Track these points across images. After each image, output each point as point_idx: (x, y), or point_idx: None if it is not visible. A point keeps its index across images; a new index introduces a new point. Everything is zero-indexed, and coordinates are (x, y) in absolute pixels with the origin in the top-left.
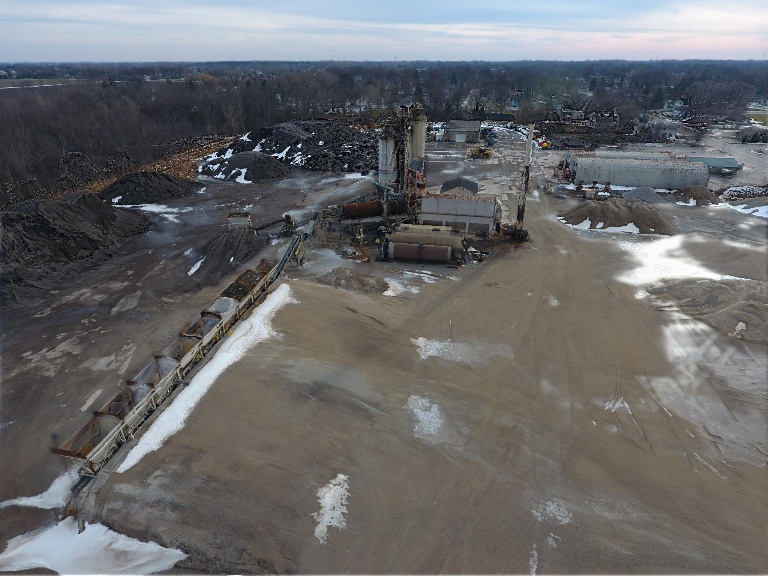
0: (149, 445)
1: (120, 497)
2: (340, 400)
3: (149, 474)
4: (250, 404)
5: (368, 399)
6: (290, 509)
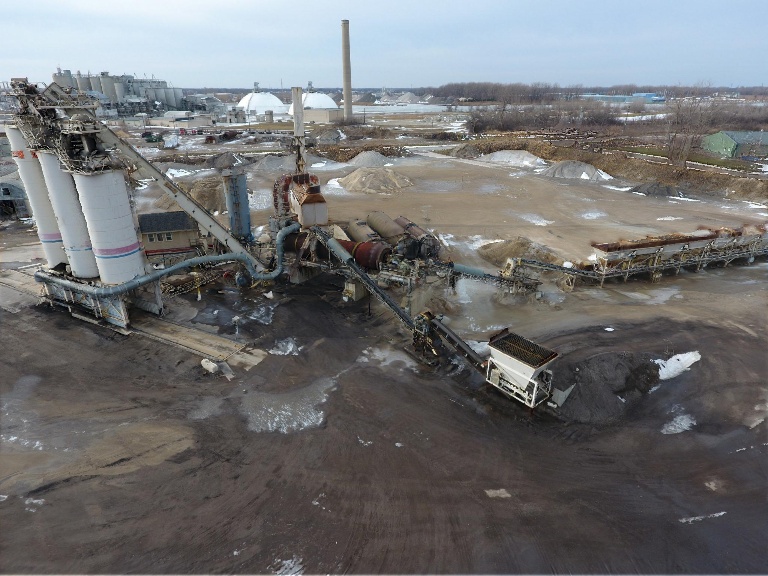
0: None
1: None
2: None
3: None
4: None
5: None
6: None
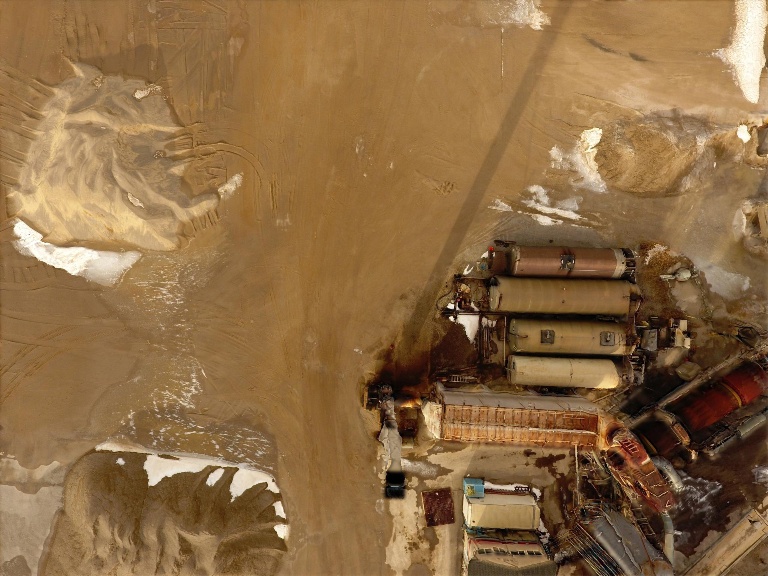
0: None
1: None
2: None
3: None
4: None
5: None
6: None
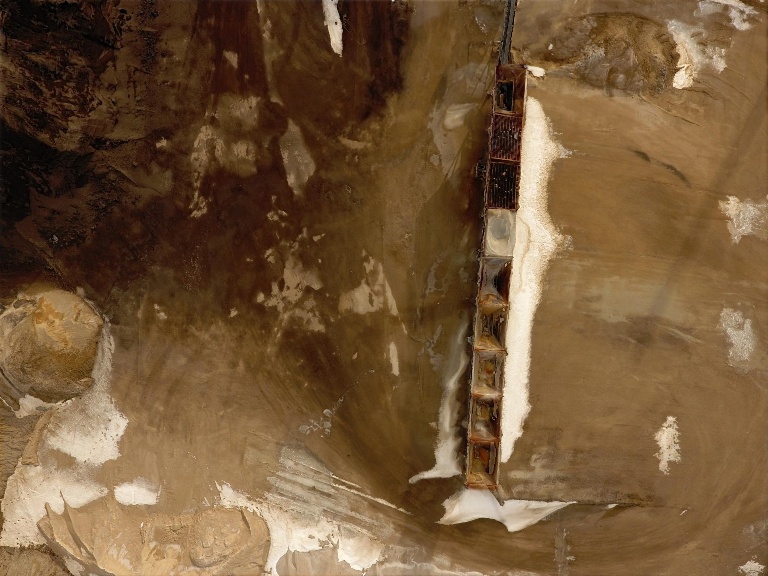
0: (513, 433)
1: (519, 482)
2: (657, 335)
3: (529, 459)
4: (579, 367)
5: (682, 324)
6: (639, 456)
